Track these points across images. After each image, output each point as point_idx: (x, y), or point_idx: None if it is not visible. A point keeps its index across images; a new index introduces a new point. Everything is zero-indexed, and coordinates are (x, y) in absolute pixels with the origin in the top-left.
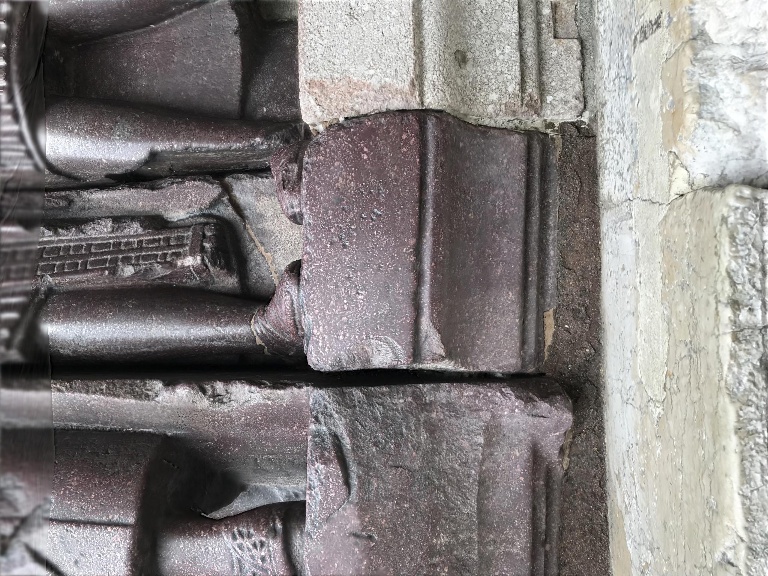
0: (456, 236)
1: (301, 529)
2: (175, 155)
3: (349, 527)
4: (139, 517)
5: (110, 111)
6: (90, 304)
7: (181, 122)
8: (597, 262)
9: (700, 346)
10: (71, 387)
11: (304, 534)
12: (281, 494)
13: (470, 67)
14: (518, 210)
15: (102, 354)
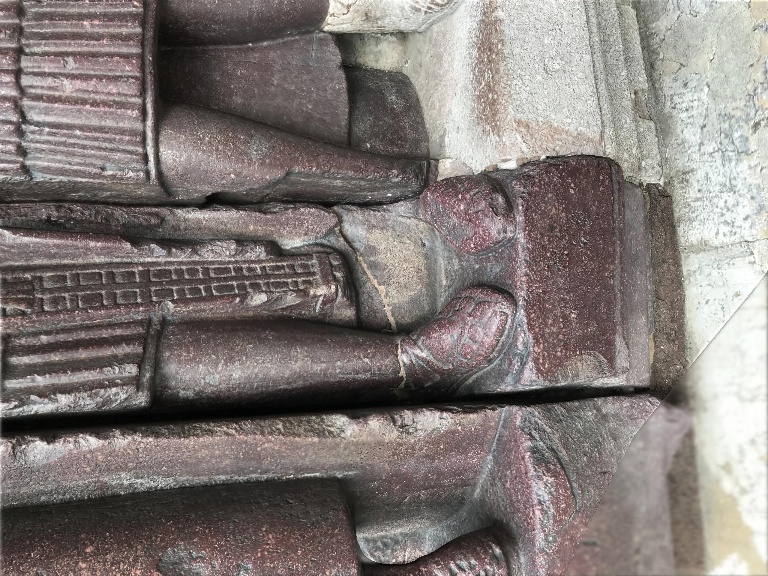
0: None
1: (517, 551)
2: (301, 179)
3: (580, 535)
4: (361, 567)
5: (242, 124)
6: (223, 335)
7: (318, 145)
8: (681, 294)
9: None
10: (242, 429)
11: (521, 555)
12: (368, 546)
13: None
14: (644, 249)
15: (230, 394)
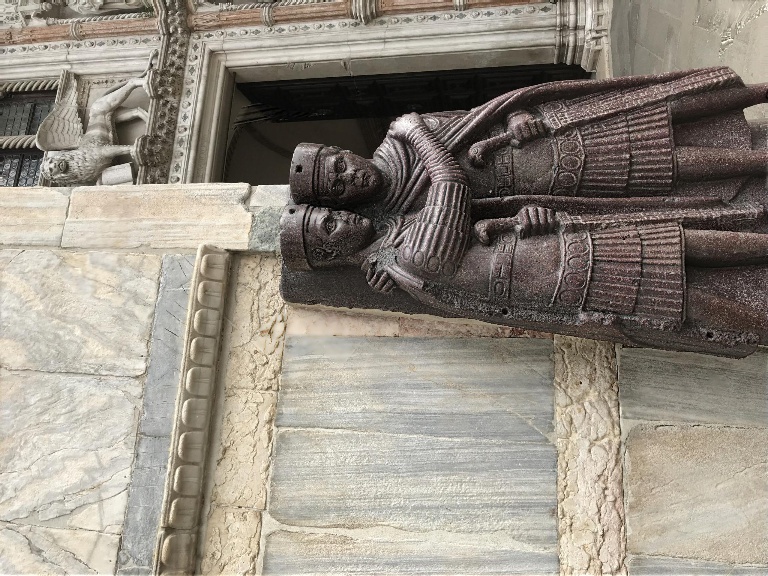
0: None
1: None
2: None
3: None
4: None
5: None
6: None
7: None
8: None
9: None
10: None
11: None
12: None
13: None
14: None
15: None
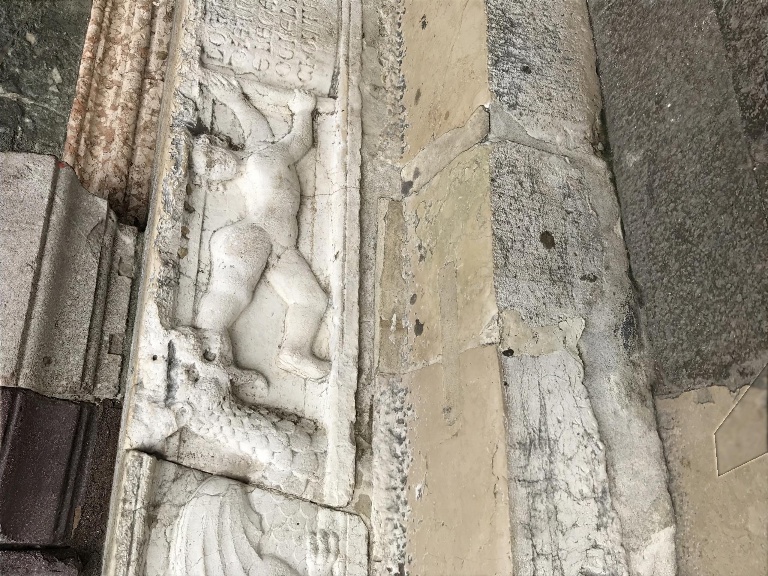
0: (23, 460)
1: None
2: None
3: None
4: None
5: None
6: None
7: None
8: (111, 479)
9: None
10: None
11: None
12: None
13: (52, 366)
14: (67, 447)
15: None
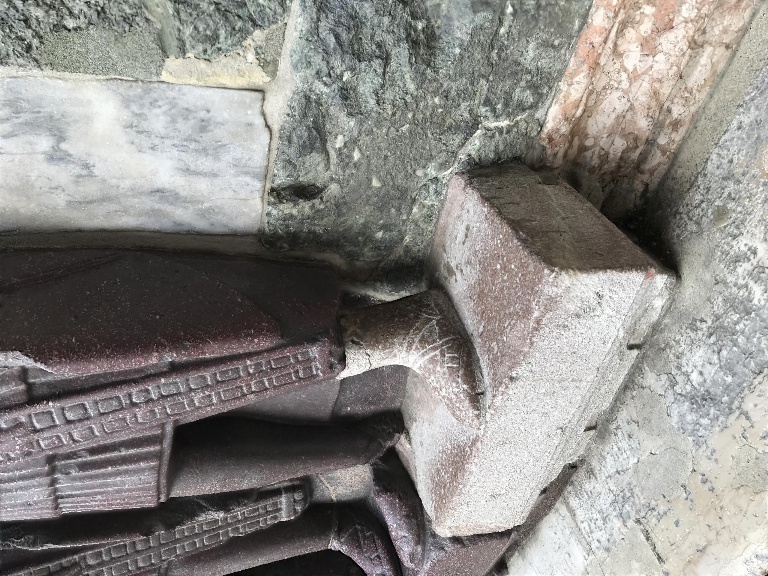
0: None
1: None
2: None
3: None
4: None
5: (238, 467)
6: (209, 564)
7: (299, 463)
8: (547, 512)
9: None
10: None
11: None
12: None
13: None
14: None
15: None
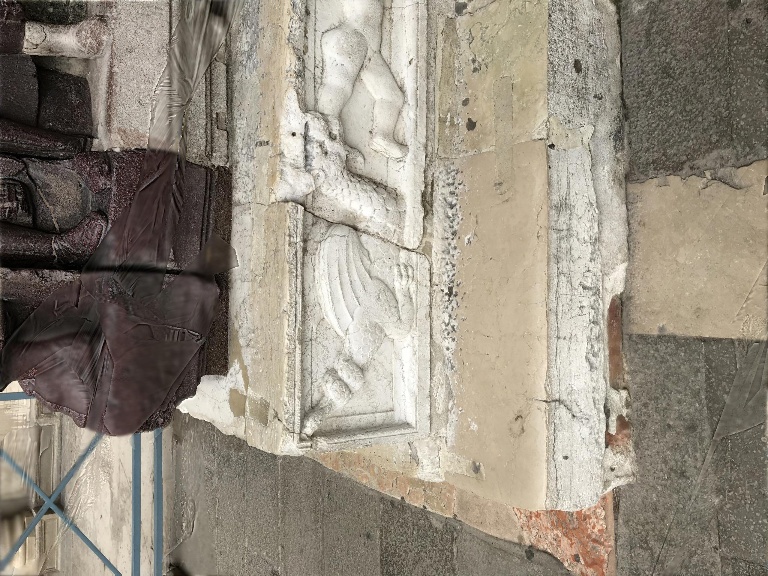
0: None
1: None
2: None
3: None
4: None
5: None
6: None
7: (10, 124)
8: (230, 228)
9: (278, 250)
10: None
11: None
12: None
13: None
14: (202, 201)
15: None
